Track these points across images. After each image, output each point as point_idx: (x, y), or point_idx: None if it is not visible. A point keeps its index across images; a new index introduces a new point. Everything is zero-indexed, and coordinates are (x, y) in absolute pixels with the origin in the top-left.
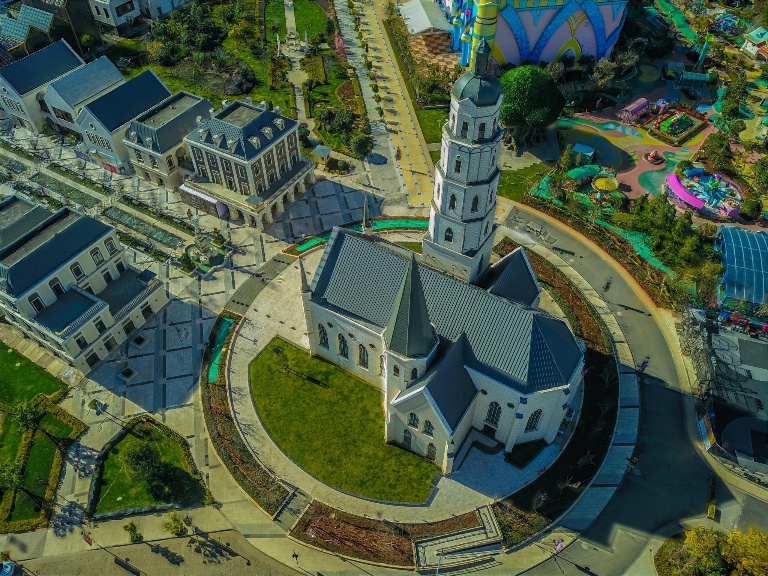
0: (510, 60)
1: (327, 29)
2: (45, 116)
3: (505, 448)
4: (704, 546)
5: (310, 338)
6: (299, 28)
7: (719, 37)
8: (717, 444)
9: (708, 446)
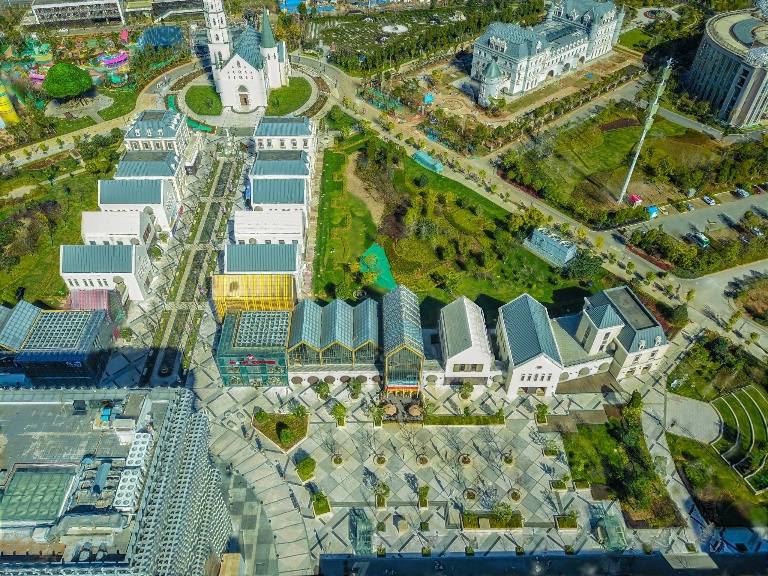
0: None
1: None
2: None
3: None
4: None
5: None
6: None
7: None
8: None
9: None
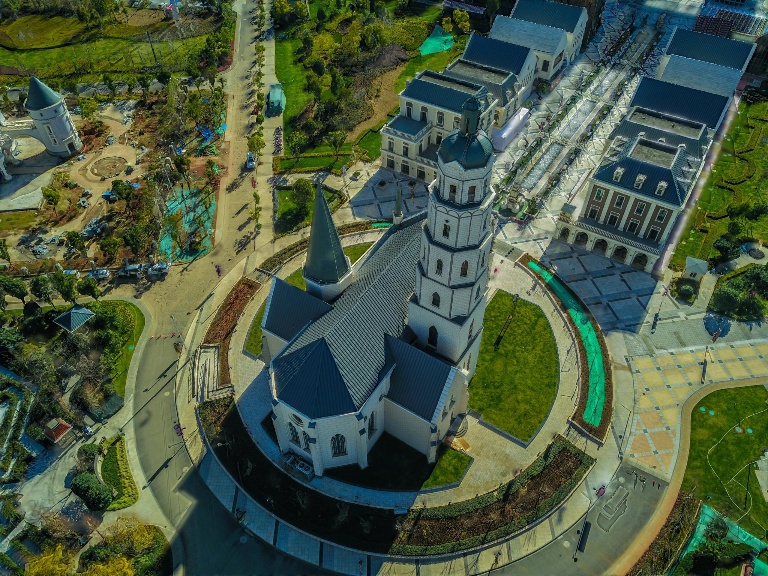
0: None
1: None
2: None
3: None
4: None
5: None
6: None
7: None
8: None
9: None
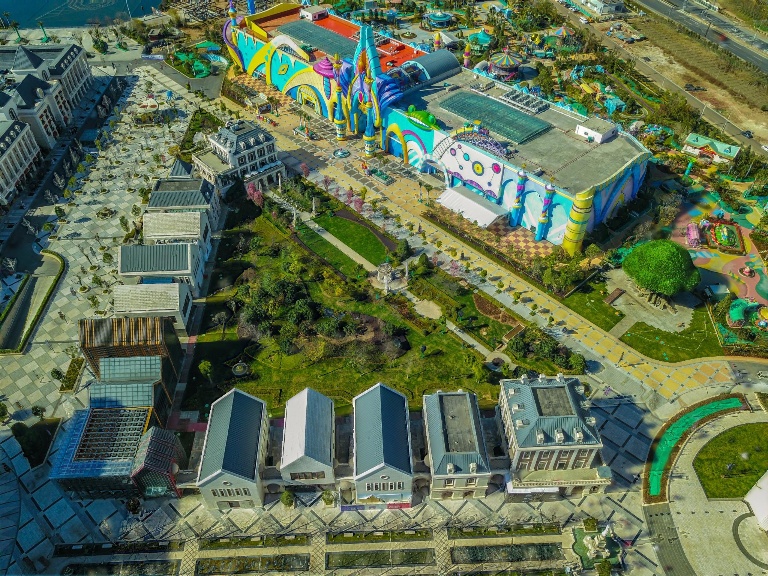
0: (588, 227)
1: (405, 248)
2: (267, 484)
3: None
4: None
5: None
6: (361, 252)
7: (658, 145)
8: None
9: None
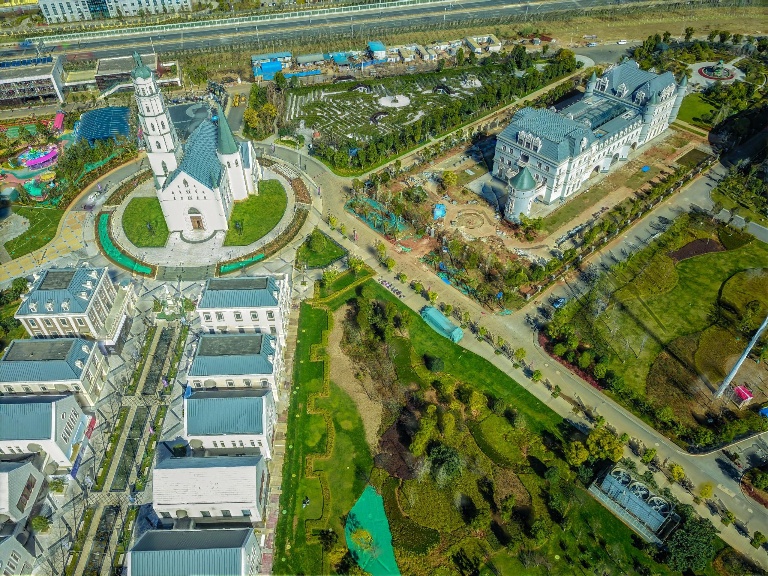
0: None
1: None
2: None
3: None
4: None
5: (225, 217)
6: None
7: None
8: None
9: None
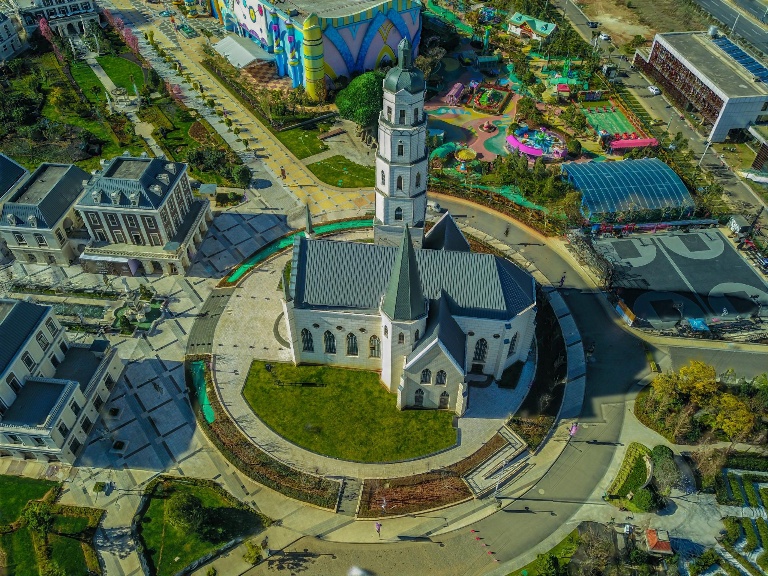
0: (340, 74)
1: (152, 79)
2: None
3: (496, 377)
4: (670, 384)
5: (294, 347)
6: (118, 84)
7: None
8: (637, 317)
9: (630, 322)
